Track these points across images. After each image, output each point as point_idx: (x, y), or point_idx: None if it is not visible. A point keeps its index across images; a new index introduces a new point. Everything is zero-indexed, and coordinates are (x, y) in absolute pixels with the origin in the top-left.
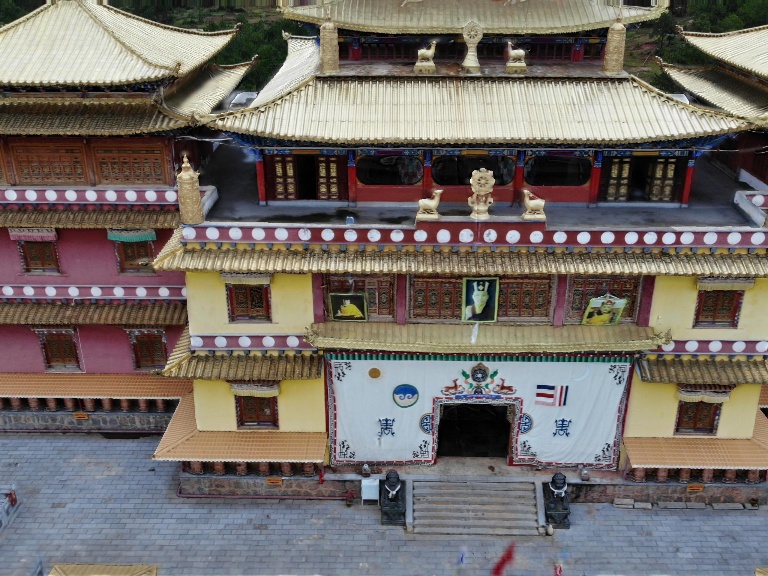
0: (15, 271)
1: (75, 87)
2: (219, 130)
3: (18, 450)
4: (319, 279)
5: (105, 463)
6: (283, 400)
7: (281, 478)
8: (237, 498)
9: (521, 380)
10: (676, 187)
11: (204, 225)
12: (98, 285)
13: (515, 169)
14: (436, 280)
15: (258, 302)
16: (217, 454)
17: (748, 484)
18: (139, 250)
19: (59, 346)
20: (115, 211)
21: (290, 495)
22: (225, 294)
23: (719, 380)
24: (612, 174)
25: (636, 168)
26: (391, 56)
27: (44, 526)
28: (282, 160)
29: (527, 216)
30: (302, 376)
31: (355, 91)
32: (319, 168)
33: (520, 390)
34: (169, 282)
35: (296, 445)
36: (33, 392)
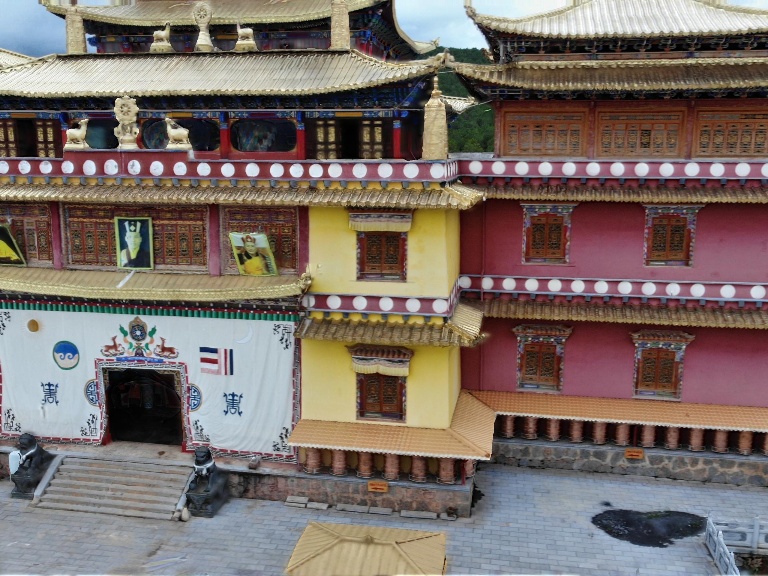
0: None
1: None
2: None
3: None
4: None
5: None
6: None
7: None
8: None
9: (182, 340)
10: (386, 152)
11: None
12: None
13: (220, 132)
14: (90, 220)
15: None
16: None
17: (439, 484)
18: None
19: None
20: None
21: None
22: None
23: (379, 338)
24: (318, 138)
25: (347, 134)
26: None
27: None
28: (4, 125)
29: (169, 146)
30: None
31: (84, 65)
32: (37, 133)
33: (182, 353)
34: None
35: None
36: None
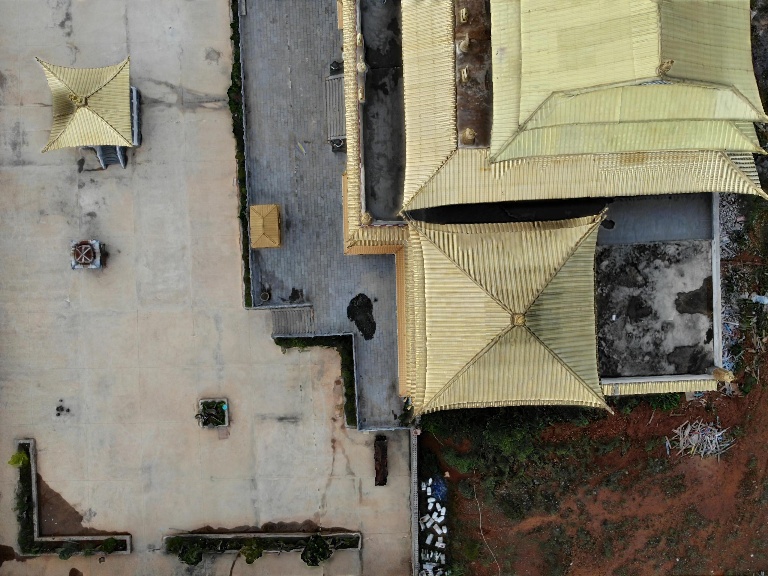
0: None
1: None
2: None
3: None
4: None
5: None
6: None
7: None
8: None
9: None
10: None
11: None
12: None
13: None
14: None
15: None
16: None
17: None
18: None
19: None
20: None
21: None
22: None
23: None
24: None
25: None
26: None
27: None
28: None
29: None
30: None
31: None
32: None
33: None
34: None
35: None
36: None
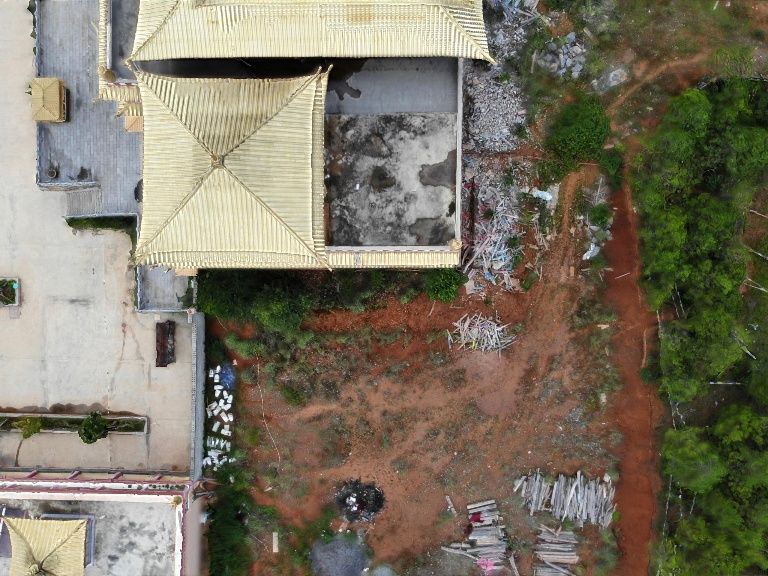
0: None
1: None
2: None
3: None
4: None
5: None
6: None
7: None
8: None
9: None
10: None
11: None
12: None
13: None
14: None
15: None
16: None
17: None
18: None
19: None
20: None
21: None
22: None
23: None
24: None
25: None
26: None
27: None
28: None
29: None
30: None
31: None
32: None
33: None
34: None
35: None
36: None
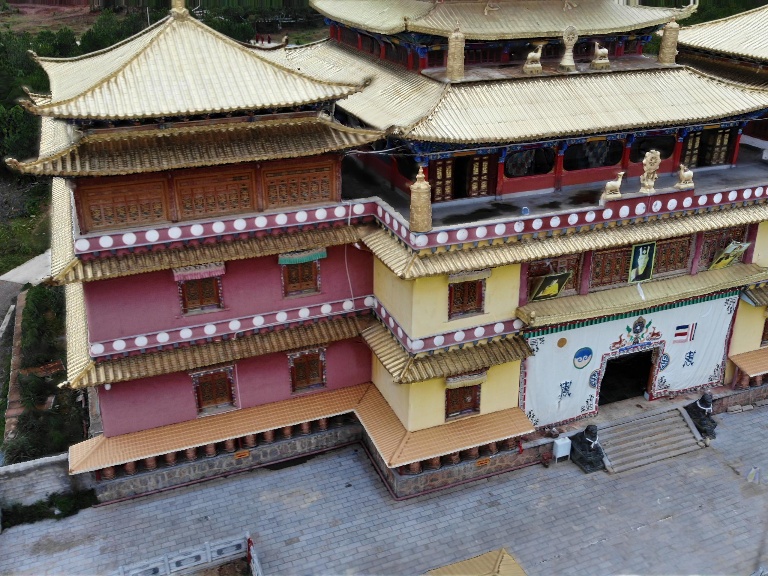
0: (172, 314)
1: (241, 111)
2: (414, 140)
3: (193, 505)
4: (527, 266)
5: (297, 492)
6: (486, 385)
7: (489, 457)
8: (450, 487)
9: (666, 325)
10: (729, 152)
11: (435, 231)
12: (261, 314)
13: (624, 150)
14: (611, 251)
15: (472, 296)
16: (444, 448)
17: None
18: (303, 271)
19: (212, 387)
20: (287, 234)
21: (494, 472)
22: (447, 294)
23: None
24: (688, 146)
25: None
26: (478, 60)
27: (298, 563)
28: (443, 164)
29: (682, 186)
30: (519, 356)
31: (490, 94)
32: (473, 168)
33: (664, 334)
34: (332, 298)
35: (503, 423)
36: (200, 440)
